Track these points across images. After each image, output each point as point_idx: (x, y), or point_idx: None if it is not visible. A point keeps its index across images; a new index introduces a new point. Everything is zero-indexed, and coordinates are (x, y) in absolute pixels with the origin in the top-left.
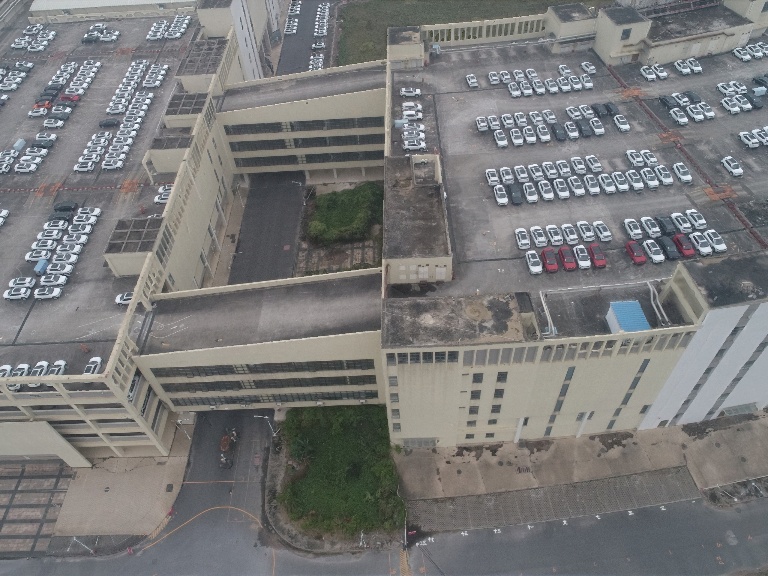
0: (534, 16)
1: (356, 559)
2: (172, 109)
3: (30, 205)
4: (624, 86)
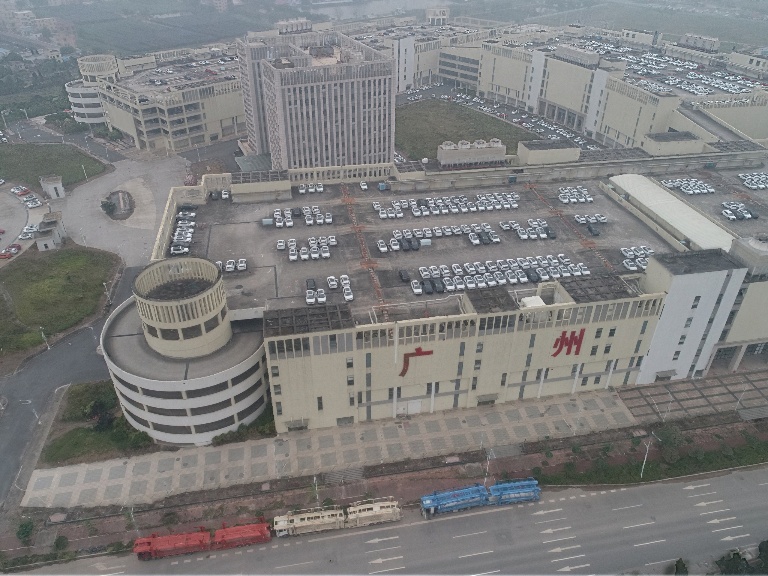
0: None
1: None
2: None
3: None
4: None
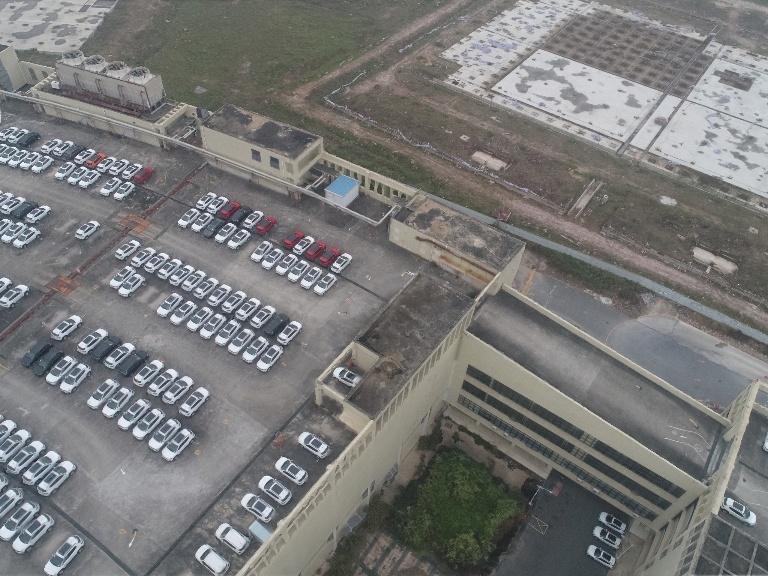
0: None
1: (552, 311)
2: None
3: None
4: None
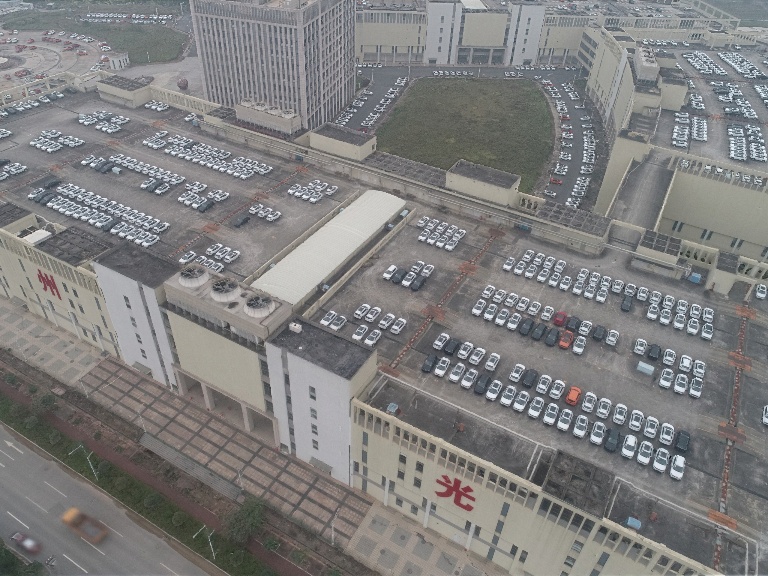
0: (633, 100)
1: None
2: (666, 251)
3: (764, 377)
4: (707, 116)
